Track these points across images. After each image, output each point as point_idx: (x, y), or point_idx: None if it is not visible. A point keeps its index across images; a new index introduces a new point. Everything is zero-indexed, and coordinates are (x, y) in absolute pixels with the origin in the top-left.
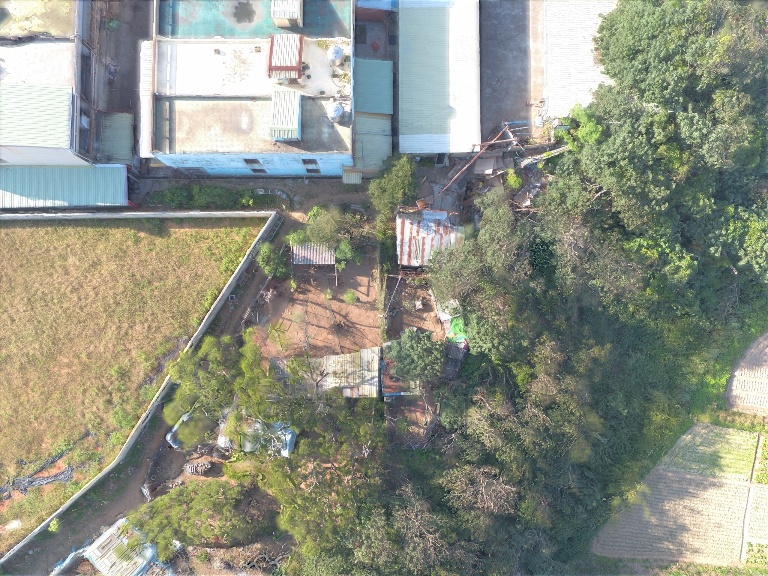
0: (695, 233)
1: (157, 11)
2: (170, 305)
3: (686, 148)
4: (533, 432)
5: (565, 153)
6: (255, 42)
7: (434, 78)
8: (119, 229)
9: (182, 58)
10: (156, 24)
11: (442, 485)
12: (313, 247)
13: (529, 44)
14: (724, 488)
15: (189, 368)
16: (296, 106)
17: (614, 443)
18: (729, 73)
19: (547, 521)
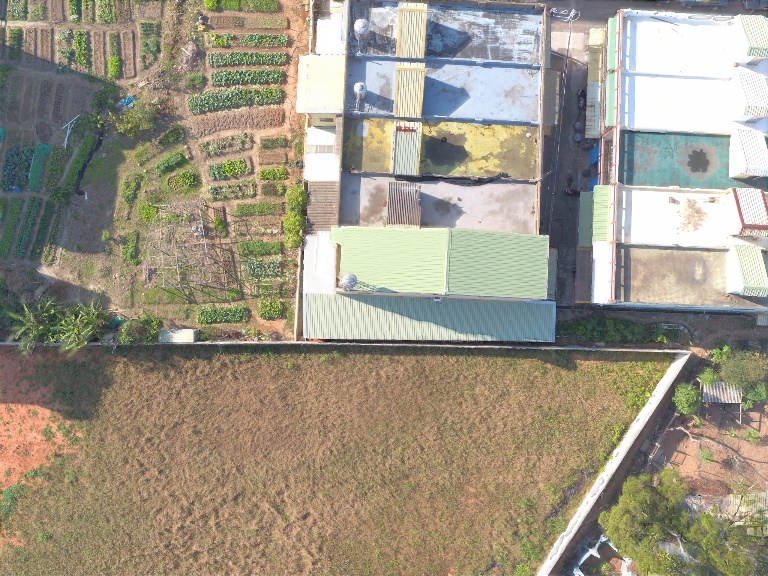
0: None
1: None
2: (577, 438)
3: None
4: None
5: None
6: (709, 192)
7: None
8: (527, 359)
9: (637, 205)
10: None
11: None
12: (722, 386)
13: None
14: None
15: (640, 517)
16: (761, 263)
17: None
18: None
19: None
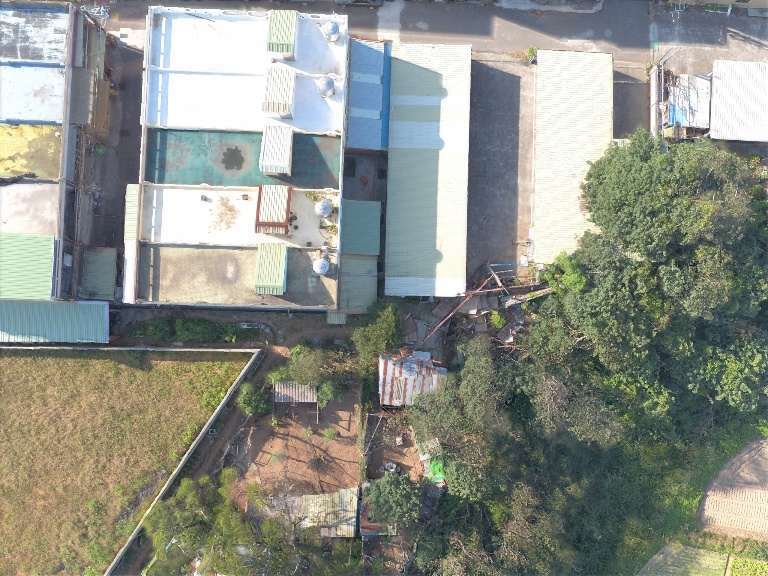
0: (674, 370)
1: (144, 155)
2: (149, 439)
3: (668, 296)
4: (508, 572)
5: (549, 297)
6: (242, 190)
7: (421, 220)
8: (99, 360)
9: (168, 203)
10: (142, 169)
11: None
12: (295, 385)
13: (517, 182)
14: None
15: (167, 519)
16: (282, 261)
17: (587, 563)
18: (712, 236)
19: None
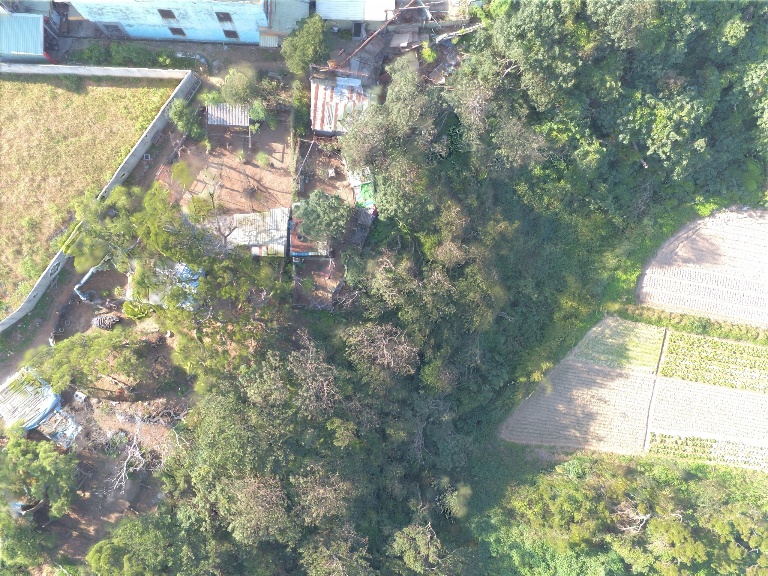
0: (604, 120)
1: None
2: (84, 160)
3: (594, 28)
4: (438, 298)
5: (477, 29)
6: None
7: None
8: (36, 84)
9: None
10: None
11: (343, 339)
12: (228, 108)
13: None
14: (631, 380)
15: (94, 208)
16: None
17: (526, 331)
18: None
19: (455, 398)
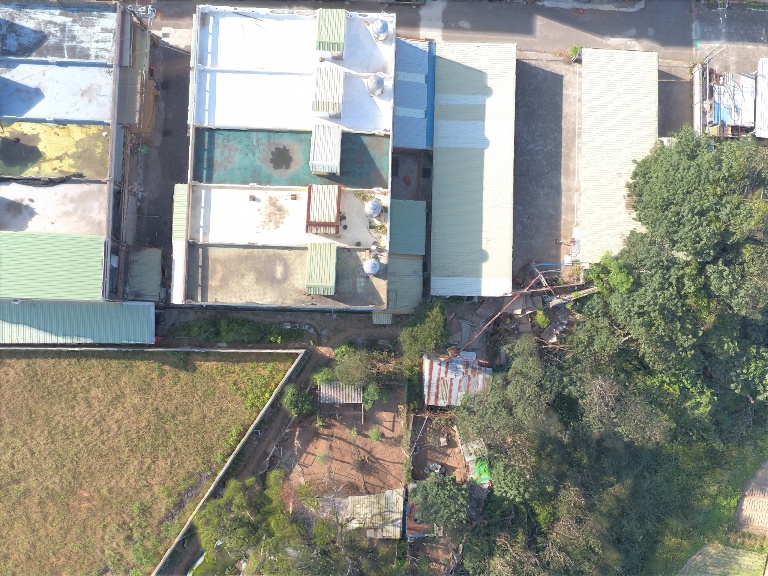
0: (716, 370)
1: (192, 155)
2: (194, 440)
3: (714, 296)
4: (554, 573)
5: (594, 297)
6: (291, 189)
7: (467, 220)
8: (143, 361)
9: (216, 203)
10: (191, 169)
11: None
12: (341, 386)
13: (560, 181)
14: None
15: (216, 520)
16: (332, 261)
17: (627, 564)
18: (762, 234)
19: None
